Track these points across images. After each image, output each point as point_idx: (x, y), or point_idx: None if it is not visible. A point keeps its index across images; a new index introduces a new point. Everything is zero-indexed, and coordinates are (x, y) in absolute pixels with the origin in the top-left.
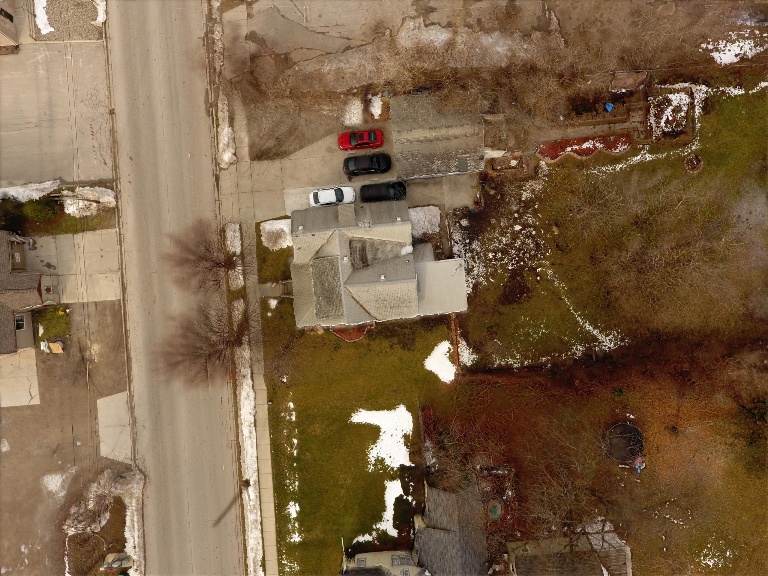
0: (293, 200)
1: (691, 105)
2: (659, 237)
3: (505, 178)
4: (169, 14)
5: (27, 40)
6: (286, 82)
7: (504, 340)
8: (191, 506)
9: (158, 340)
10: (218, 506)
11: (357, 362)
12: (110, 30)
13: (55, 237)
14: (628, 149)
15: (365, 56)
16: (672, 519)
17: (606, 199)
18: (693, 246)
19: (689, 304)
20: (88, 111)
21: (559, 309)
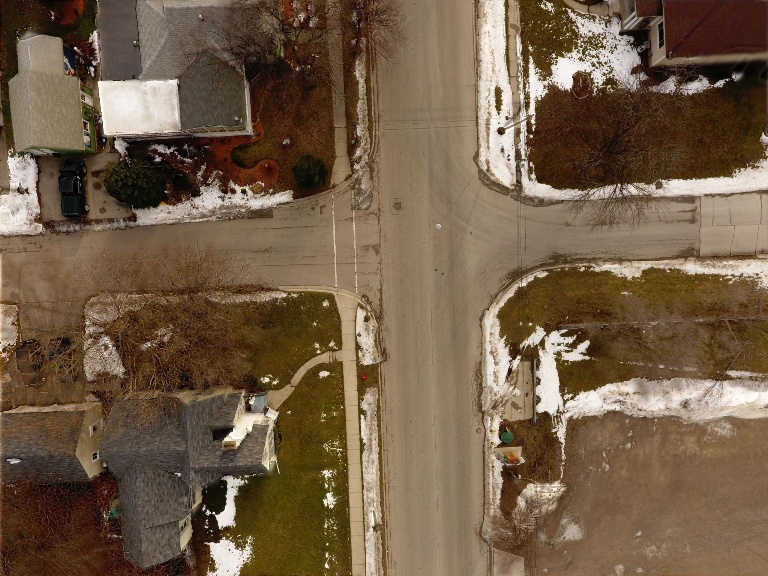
0: None
1: None
2: None
3: None
4: None
5: None
6: None
7: None
8: (435, 505)
9: None
10: (407, 504)
11: None
12: None
13: None
14: None
15: None
16: None
17: None
18: None
19: None
20: None
21: None
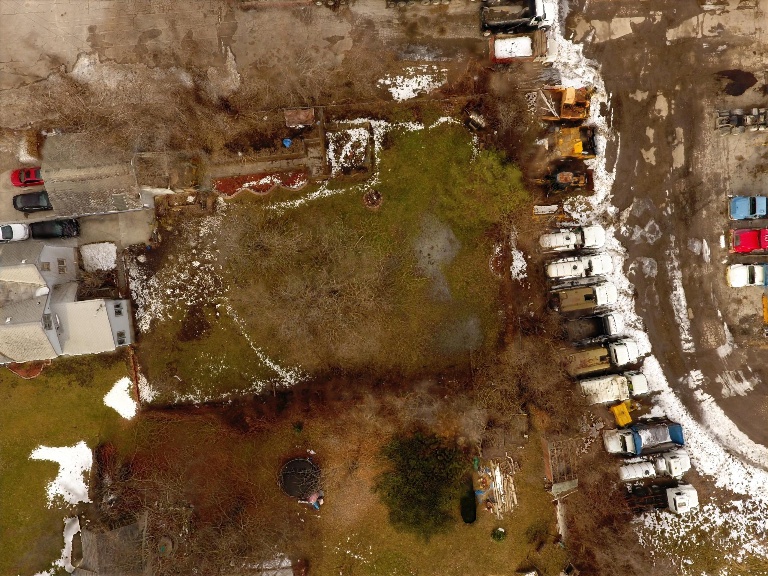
0: None
1: (370, 140)
2: (340, 272)
3: (182, 214)
4: None
5: None
6: None
7: (184, 376)
8: None
9: None
10: None
11: (35, 399)
12: None
13: None
14: (306, 185)
15: (36, 93)
16: (352, 555)
17: (285, 235)
18: (374, 281)
19: (370, 339)
20: None
21: (239, 345)
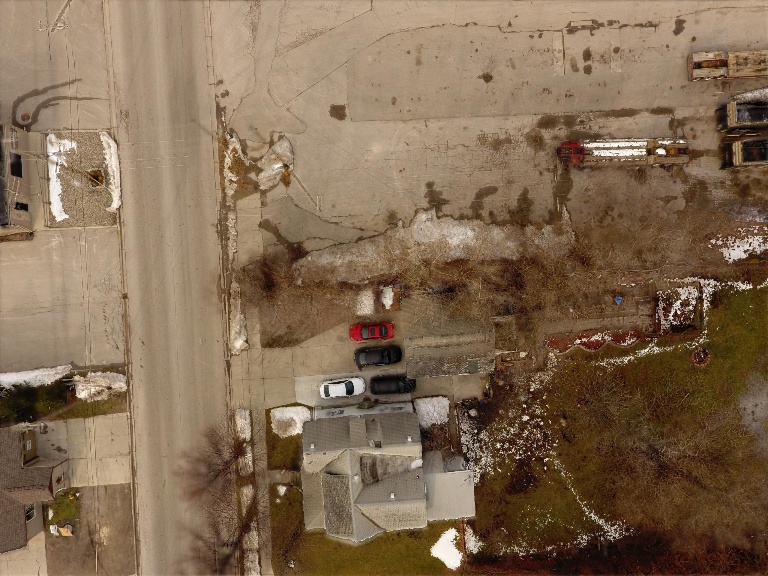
0: (303, 387)
1: (699, 299)
2: (665, 428)
3: (514, 369)
4: (183, 201)
5: (42, 227)
6: (299, 272)
7: (510, 529)
8: None
9: (167, 524)
10: None
11: (364, 549)
12: (124, 215)
13: (66, 421)
14: (636, 342)
15: (377, 249)
16: None
17: (614, 391)
18: (699, 438)
19: (694, 495)
20: (101, 296)
21: (565, 499)
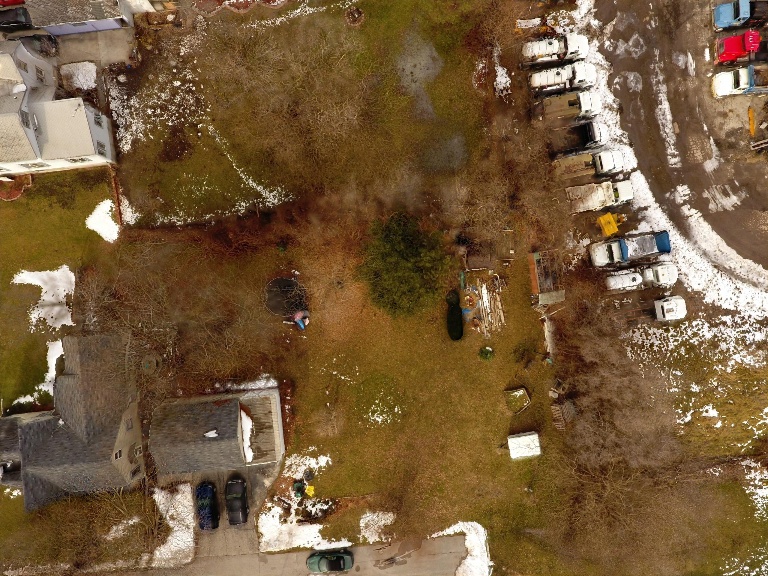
0: None
1: None
2: (322, 91)
3: (162, 33)
4: None
5: None
6: None
7: (166, 197)
8: None
9: None
10: None
11: (16, 222)
12: None
13: None
14: (286, 2)
15: None
16: (339, 375)
17: (266, 53)
18: (357, 100)
19: (354, 159)
20: None
21: (221, 165)
